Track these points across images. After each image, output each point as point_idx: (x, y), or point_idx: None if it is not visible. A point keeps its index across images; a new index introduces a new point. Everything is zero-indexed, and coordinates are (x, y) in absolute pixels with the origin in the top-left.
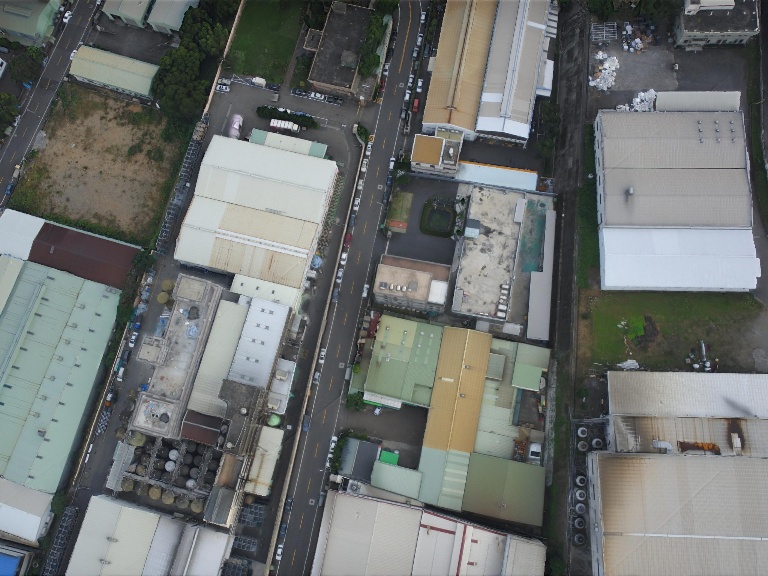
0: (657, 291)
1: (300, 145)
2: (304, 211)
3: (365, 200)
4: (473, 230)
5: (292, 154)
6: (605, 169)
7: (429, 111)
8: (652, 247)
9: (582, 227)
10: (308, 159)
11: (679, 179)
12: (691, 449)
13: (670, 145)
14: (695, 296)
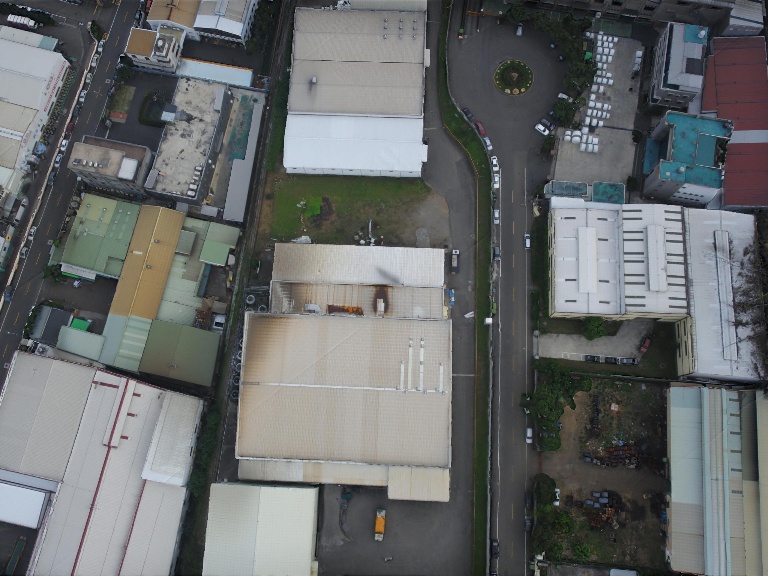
0: (338, 175)
1: (32, 38)
2: (25, 98)
3: (92, 93)
4: (169, 114)
5: (20, 45)
6: (295, 61)
7: (153, 9)
8: (328, 132)
9: (276, 116)
10: (35, 50)
11: (361, 71)
12: (337, 311)
13: (356, 40)
14: (372, 180)
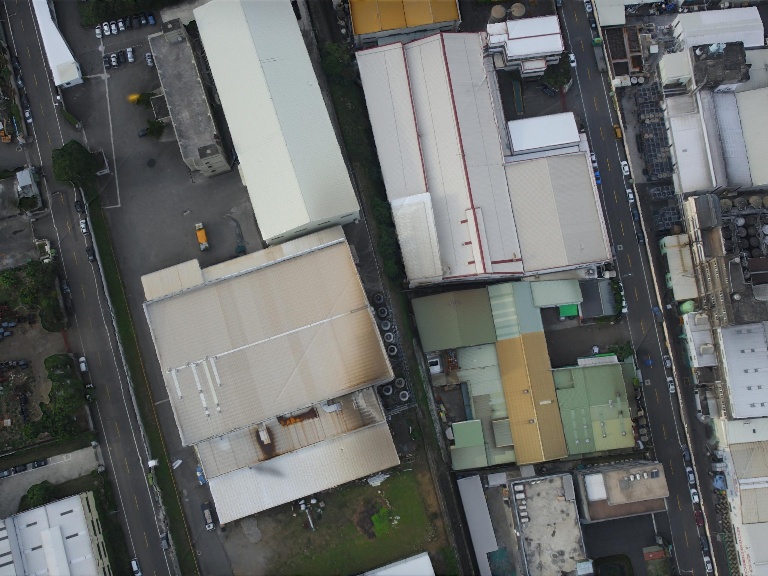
0: (370, 570)
1: None
2: (766, 533)
3: (701, 573)
4: (585, 572)
5: None
6: None
7: None
8: None
9: None
10: None
11: None
12: (306, 413)
13: None
14: None
